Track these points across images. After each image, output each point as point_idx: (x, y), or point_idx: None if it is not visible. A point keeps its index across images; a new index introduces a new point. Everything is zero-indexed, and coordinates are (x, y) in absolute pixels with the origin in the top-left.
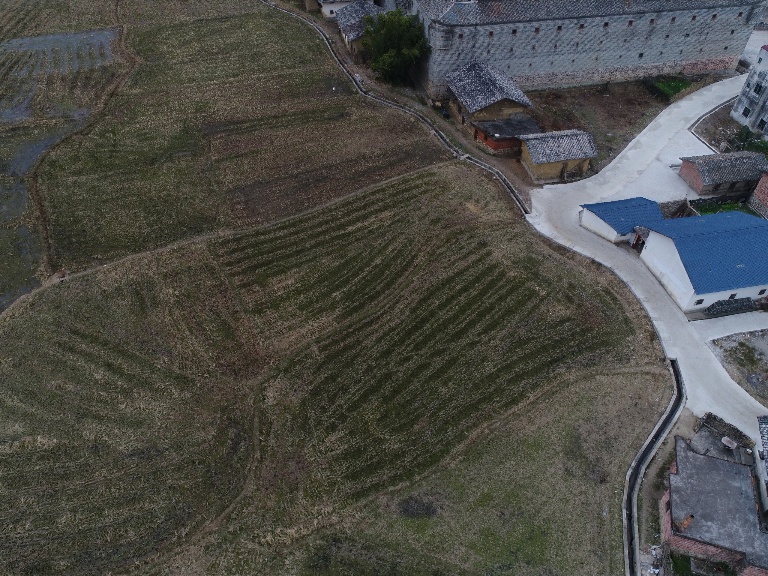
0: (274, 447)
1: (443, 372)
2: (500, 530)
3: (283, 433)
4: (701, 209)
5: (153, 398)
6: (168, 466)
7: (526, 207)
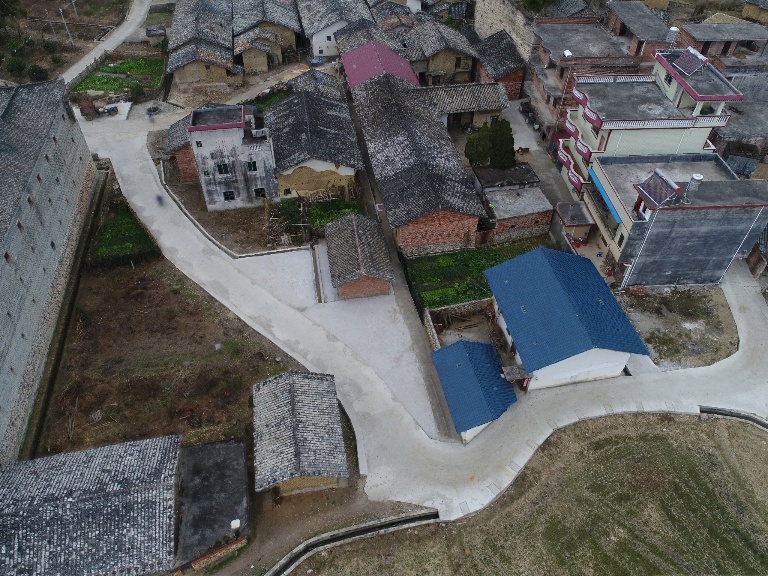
0: None
1: None
2: None
3: None
4: (419, 301)
5: None
6: None
7: (418, 514)
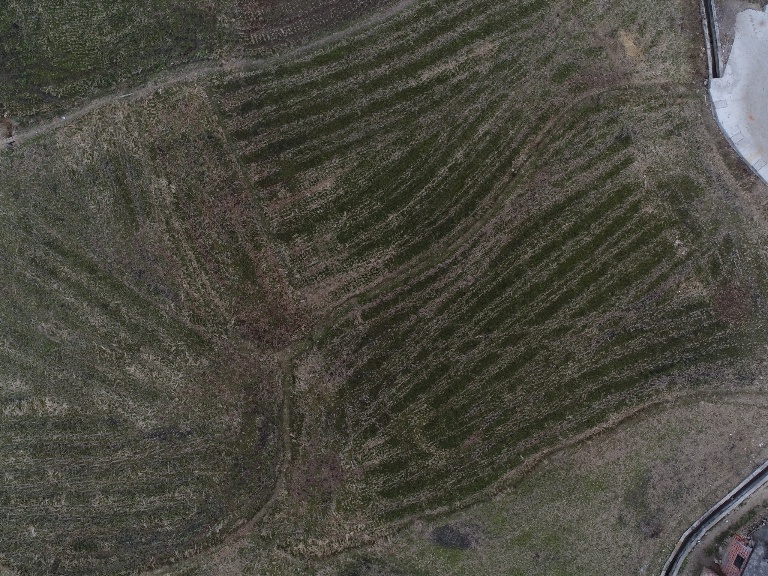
0: (306, 447)
1: (513, 370)
2: (530, 572)
3: (316, 430)
4: None
5: (165, 363)
6: (193, 453)
7: (719, 58)
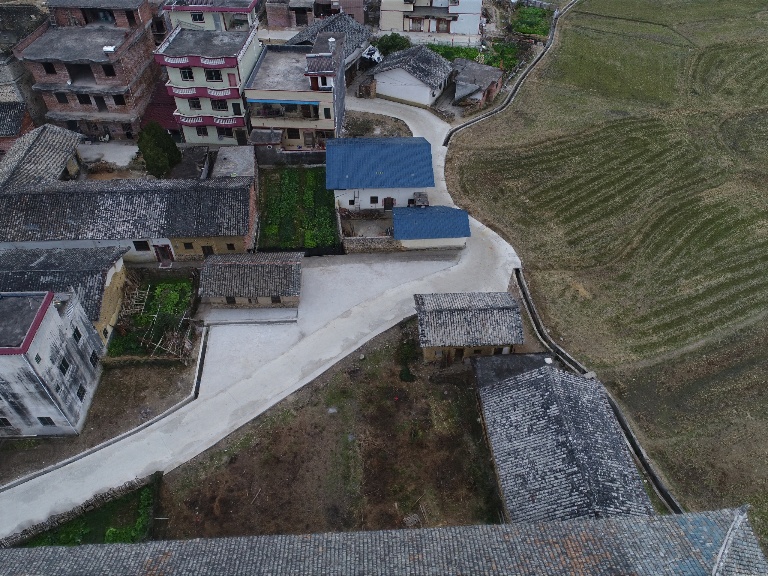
0: None
1: (609, 160)
2: None
3: None
4: None
5: None
6: None
7: None
